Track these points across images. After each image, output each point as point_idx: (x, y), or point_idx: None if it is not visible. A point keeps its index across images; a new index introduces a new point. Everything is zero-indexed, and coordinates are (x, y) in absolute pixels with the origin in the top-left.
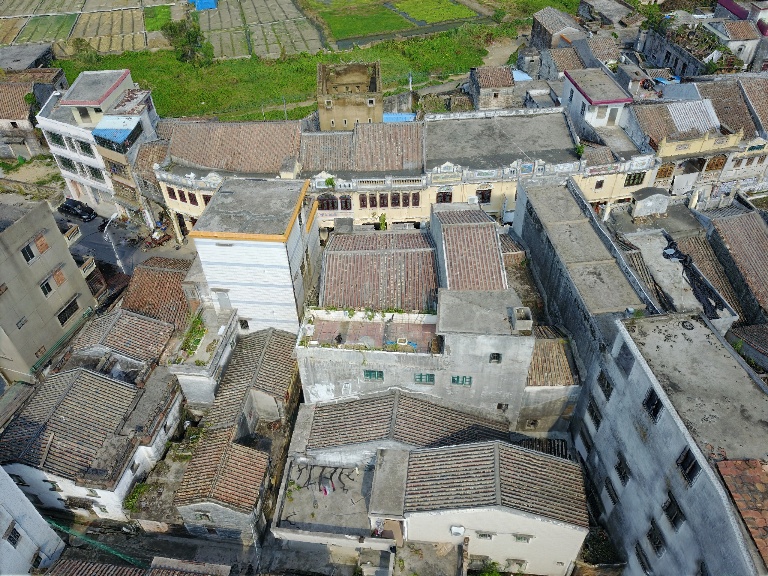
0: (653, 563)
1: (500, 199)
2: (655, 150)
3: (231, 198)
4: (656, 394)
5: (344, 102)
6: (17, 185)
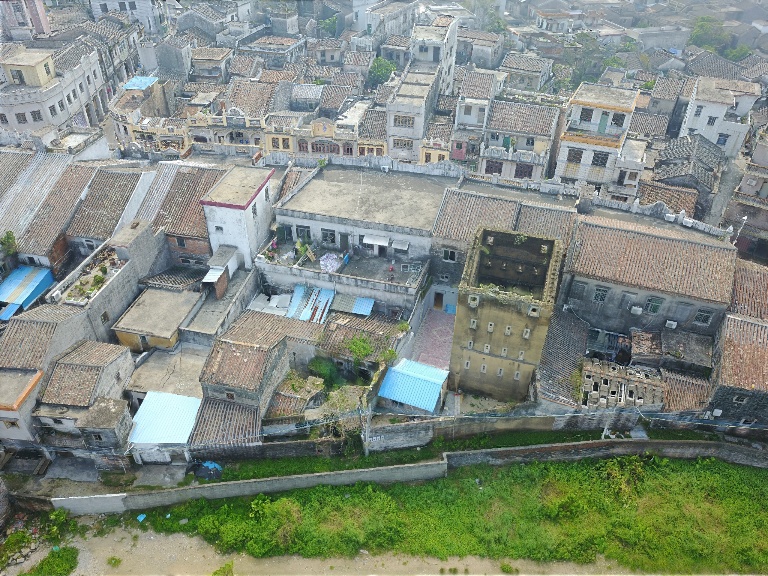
0: None
1: None
2: None
3: (622, 101)
4: None
5: None
6: None
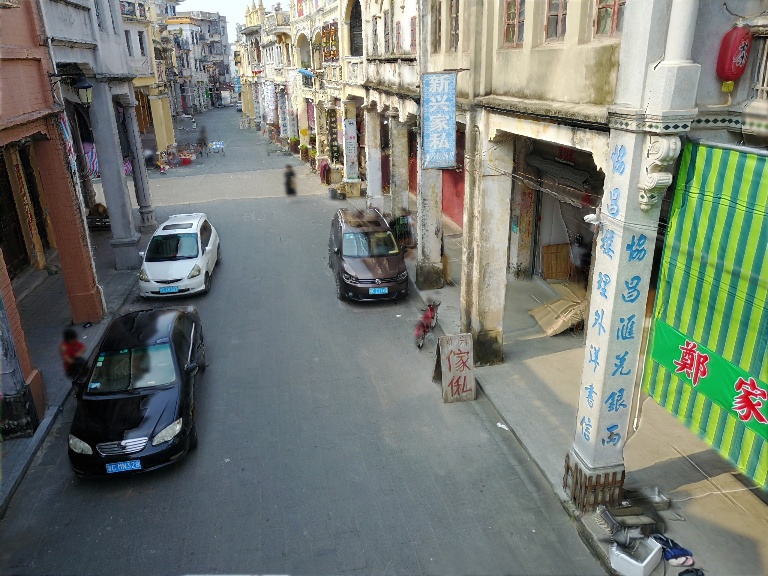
0: None
1: None
2: None
3: None
4: None
5: None
6: (212, 15)
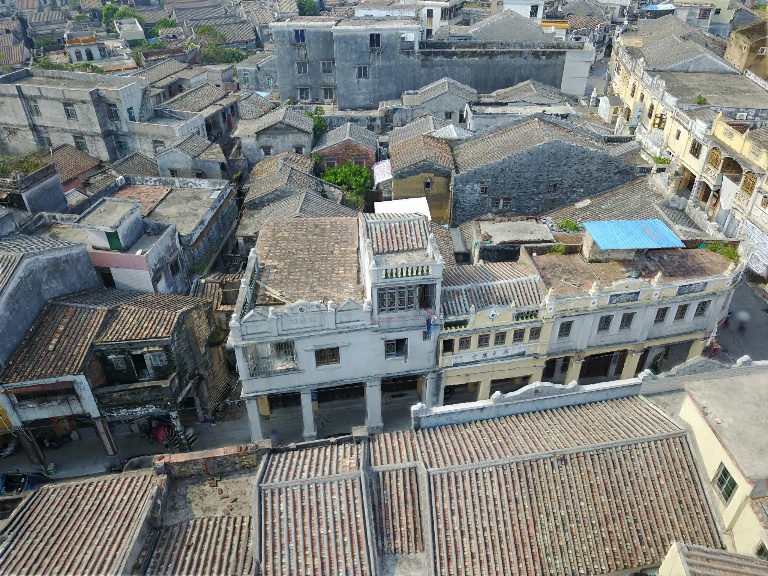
0: None
1: None
2: None
3: None
4: None
5: (737, 42)
6: None
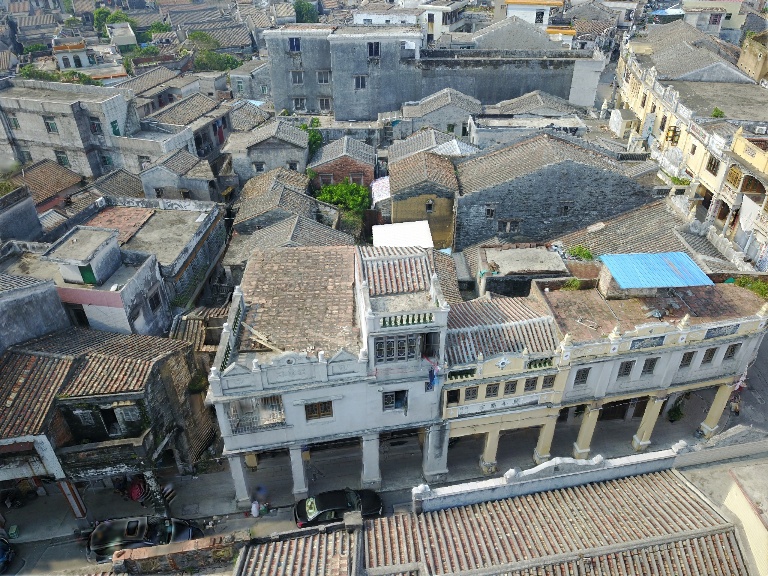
0: None
1: None
2: None
3: None
4: None
5: None
6: None
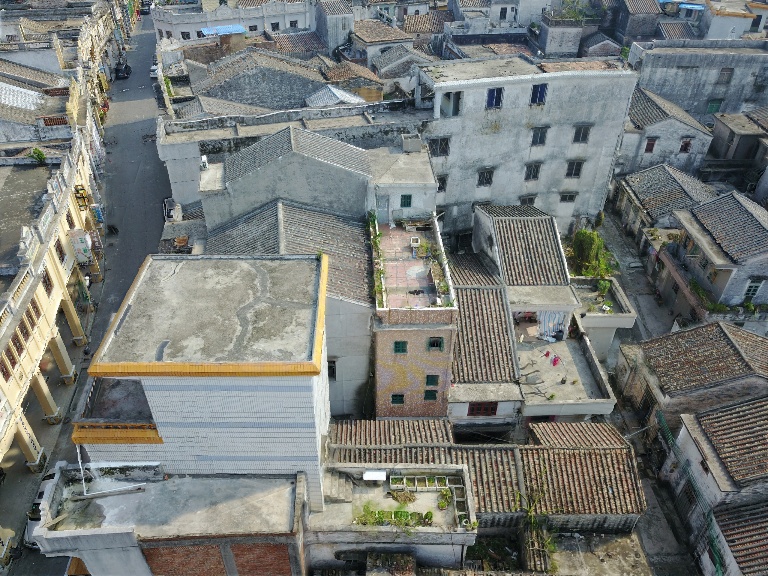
0: (536, 189)
1: (67, 242)
2: (63, 124)
3: (187, 340)
4: (494, 89)
5: None
6: None
